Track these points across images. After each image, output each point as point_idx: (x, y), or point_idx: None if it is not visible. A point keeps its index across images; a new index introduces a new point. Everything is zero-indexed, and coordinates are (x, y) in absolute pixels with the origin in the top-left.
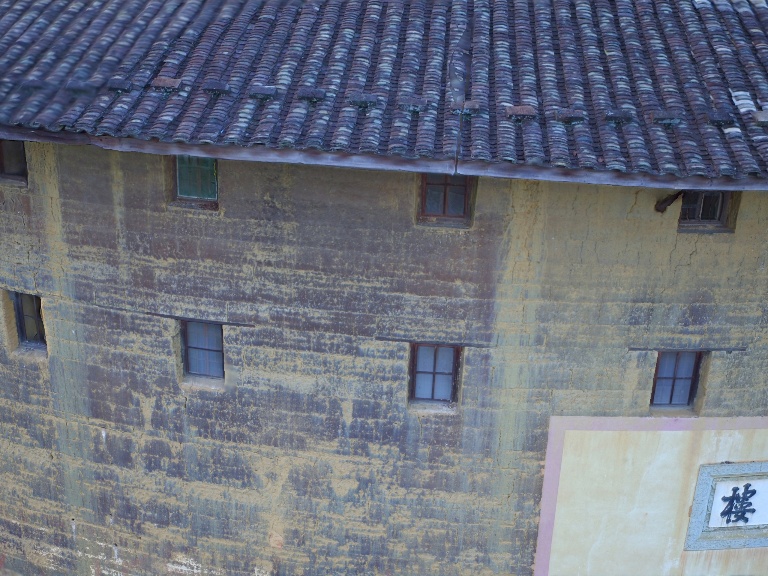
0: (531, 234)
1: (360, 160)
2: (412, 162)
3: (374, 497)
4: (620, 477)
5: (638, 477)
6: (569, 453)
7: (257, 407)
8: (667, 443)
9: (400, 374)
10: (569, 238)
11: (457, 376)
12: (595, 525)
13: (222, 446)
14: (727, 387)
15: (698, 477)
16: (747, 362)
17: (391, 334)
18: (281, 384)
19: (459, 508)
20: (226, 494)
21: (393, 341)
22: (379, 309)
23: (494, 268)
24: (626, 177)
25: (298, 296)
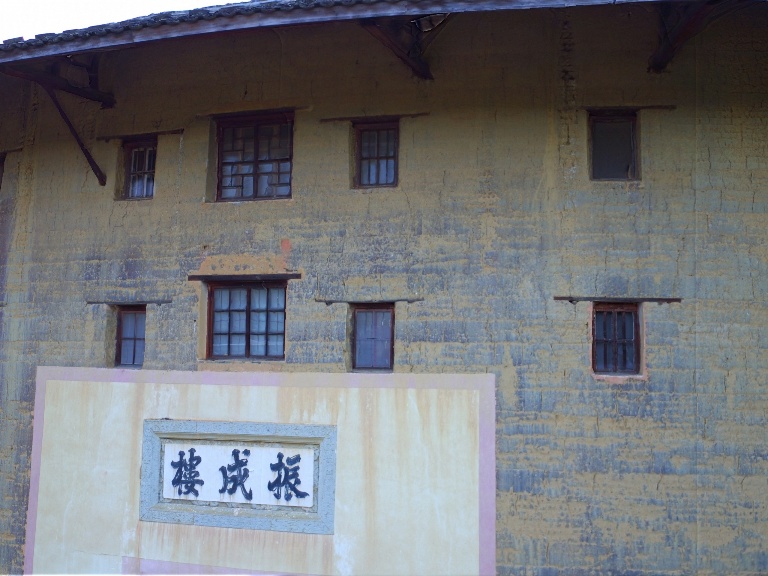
0: (28, 211)
1: None
2: None
3: None
4: (85, 430)
5: (98, 431)
6: (49, 403)
7: None
8: (118, 395)
9: None
10: (48, 211)
11: None
12: (68, 482)
13: None
14: (161, 339)
15: (144, 433)
16: (174, 314)
17: None
18: None
19: None
20: None
21: None
22: None
23: (7, 240)
24: None
25: None
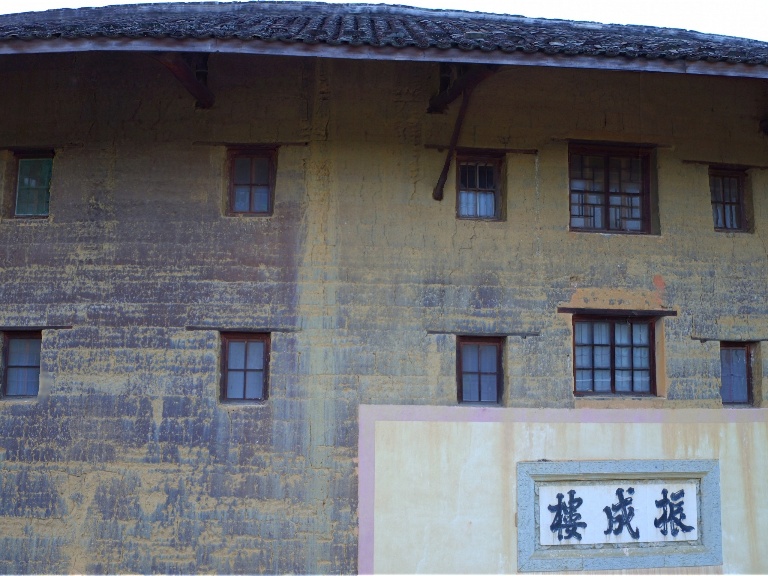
0: (326, 220)
1: (138, 44)
2: (181, 43)
3: (183, 512)
4: (437, 476)
5: (455, 477)
6: (381, 448)
7: (68, 416)
8: (479, 436)
9: (210, 365)
10: (360, 223)
11: (267, 371)
12: (418, 537)
13: (29, 468)
14: (529, 375)
15: (517, 477)
16: (543, 348)
17: (201, 323)
18: (94, 387)
19: (273, 520)
20: (28, 528)
21: (203, 330)
22: (190, 298)
23: (294, 252)
24: (355, 51)
25: (115, 291)
